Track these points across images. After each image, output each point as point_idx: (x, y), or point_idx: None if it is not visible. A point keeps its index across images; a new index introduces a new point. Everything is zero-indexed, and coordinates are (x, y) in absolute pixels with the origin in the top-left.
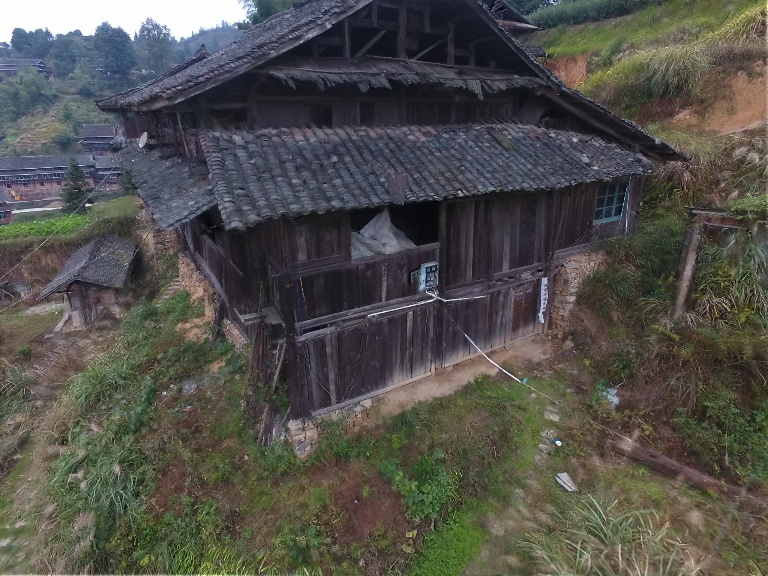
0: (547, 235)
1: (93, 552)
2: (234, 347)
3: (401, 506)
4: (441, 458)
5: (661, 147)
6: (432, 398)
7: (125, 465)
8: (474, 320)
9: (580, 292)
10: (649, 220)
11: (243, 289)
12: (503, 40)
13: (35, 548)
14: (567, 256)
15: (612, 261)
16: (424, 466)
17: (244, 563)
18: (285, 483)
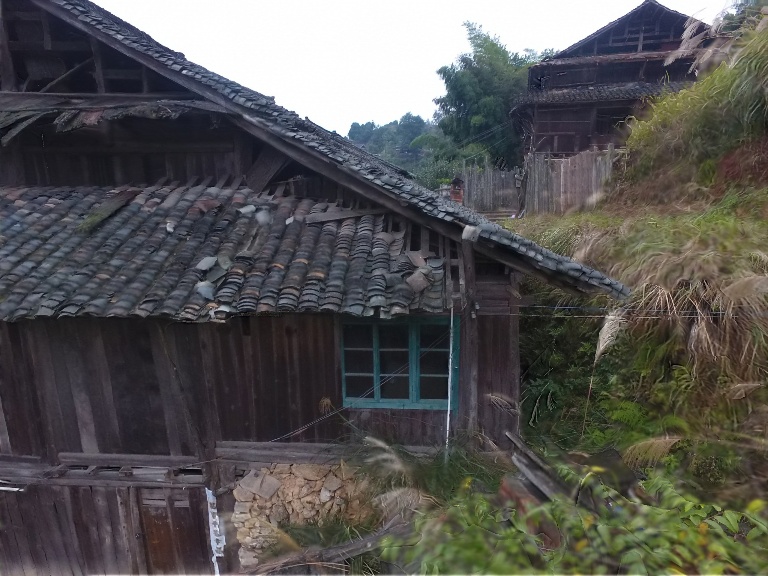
0: (196, 405)
1: None
2: None
3: None
4: None
5: (503, 249)
6: None
7: None
8: (44, 523)
9: (263, 552)
10: (611, 427)
11: None
12: (99, 40)
13: None
14: (271, 459)
15: None
16: None
17: None
18: None
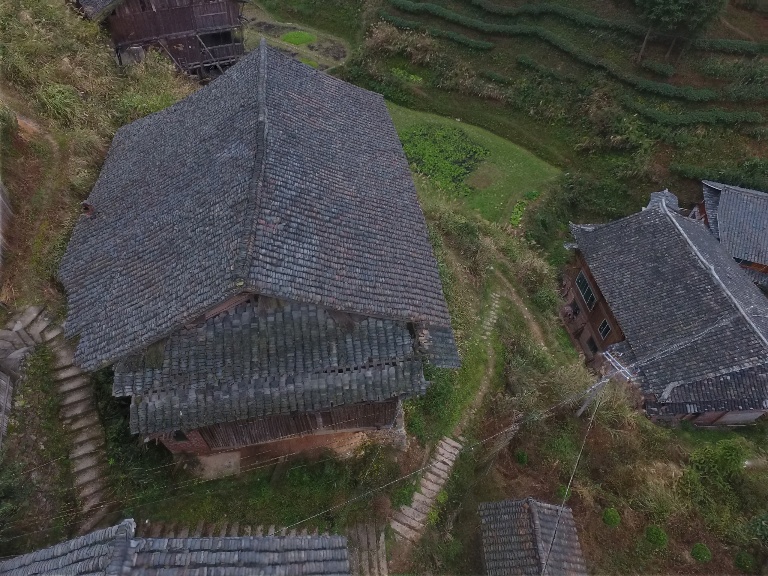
0: None
1: None
2: None
3: None
4: None
5: None
6: None
7: None
8: None
9: None
10: None
11: None
12: None
13: None
14: None
15: None
16: None
17: None
18: None
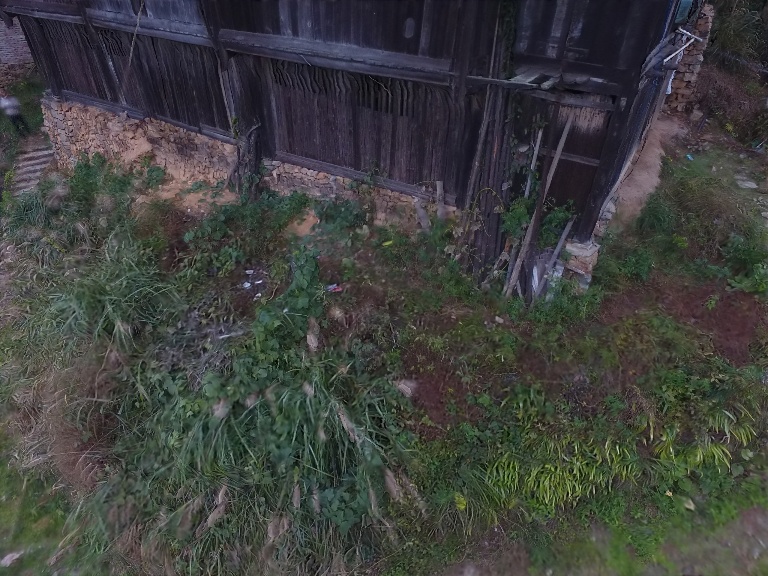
0: None
1: (357, 530)
2: (307, 197)
3: (761, 304)
4: (741, 243)
5: None
6: (655, 188)
7: (330, 392)
8: None
9: (709, 48)
10: None
11: (475, 38)
12: None
13: (90, 575)
14: None
15: (717, 12)
16: (755, 253)
17: (616, 442)
18: (589, 330)
